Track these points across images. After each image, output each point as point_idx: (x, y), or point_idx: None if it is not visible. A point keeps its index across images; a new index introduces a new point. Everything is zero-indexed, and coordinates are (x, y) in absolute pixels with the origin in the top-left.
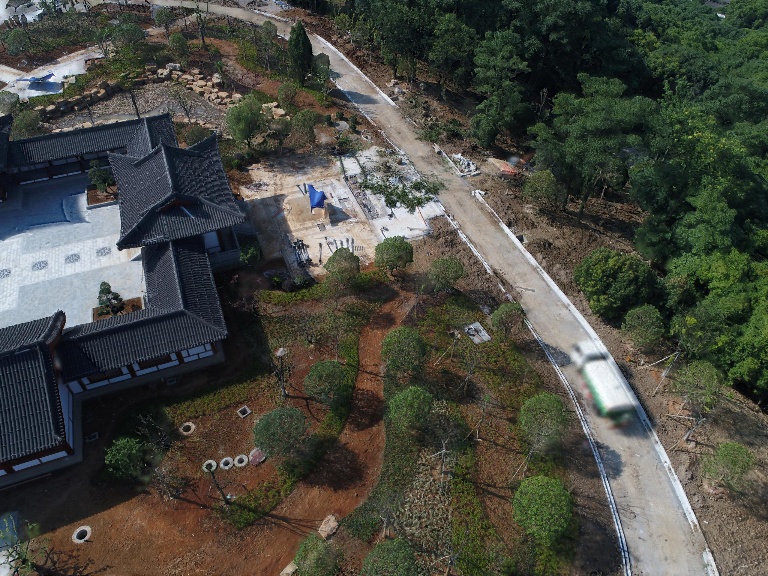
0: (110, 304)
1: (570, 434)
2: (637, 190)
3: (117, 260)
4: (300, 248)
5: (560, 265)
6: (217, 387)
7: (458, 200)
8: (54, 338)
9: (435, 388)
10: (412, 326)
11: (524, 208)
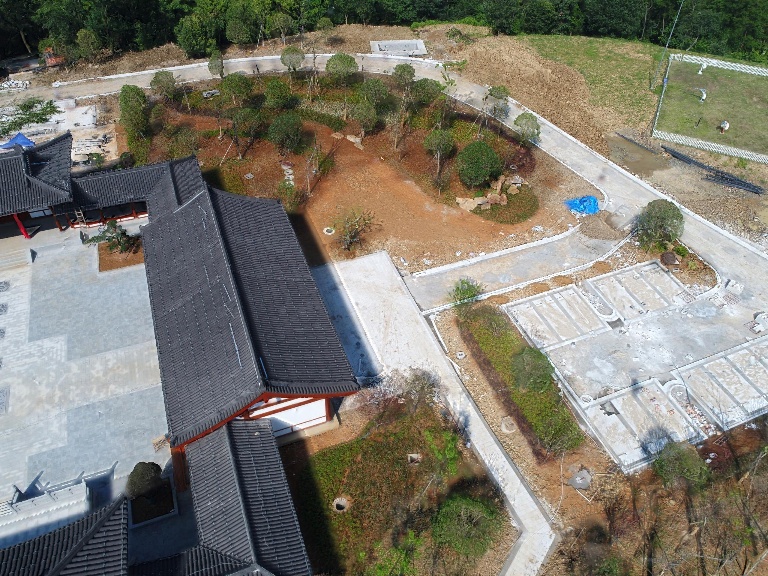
0: (121, 232)
1: (293, 74)
2: (103, 26)
3: (24, 273)
4: (76, 164)
5: (163, 62)
6: (224, 189)
7: (59, 93)
8: None
9: (254, 103)
10: (198, 111)
11: (92, 67)
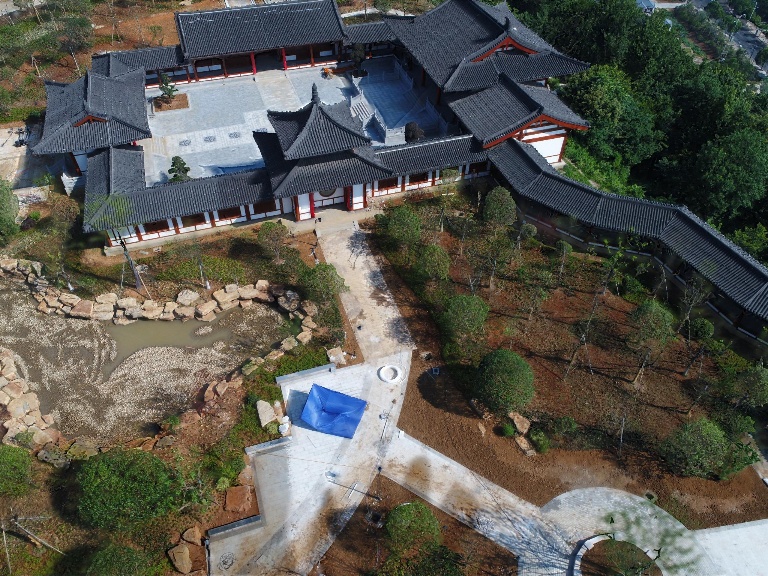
0: None
1: None
2: None
3: (174, 137)
4: None
5: None
6: None
7: None
8: (177, 29)
9: None
10: None
11: None
